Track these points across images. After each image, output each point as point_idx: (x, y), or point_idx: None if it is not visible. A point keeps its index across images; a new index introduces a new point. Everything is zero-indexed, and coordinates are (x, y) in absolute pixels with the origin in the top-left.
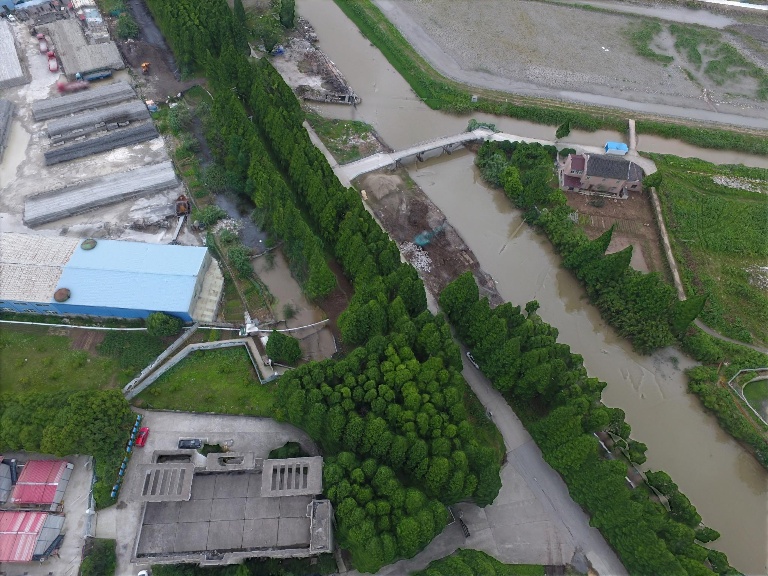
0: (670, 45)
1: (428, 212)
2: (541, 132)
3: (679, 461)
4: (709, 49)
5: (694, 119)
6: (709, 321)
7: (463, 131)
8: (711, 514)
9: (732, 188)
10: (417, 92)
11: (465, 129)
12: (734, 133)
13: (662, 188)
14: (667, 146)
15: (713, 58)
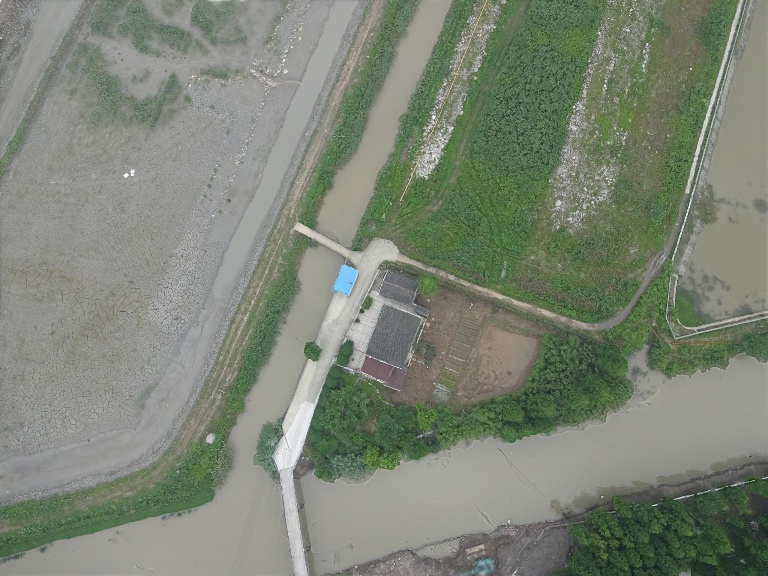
0: (137, 57)
1: (399, 572)
2: (285, 358)
3: (715, 407)
4: (162, 1)
5: (310, 130)
6: (609, 315)
7: (263, 470)
8: (765, 410)
9: (440, 162)
10: (171, 512)
11: (260, 467)
12: (349, 92)
13: (422, 254)
14: (345, 192)
15: (183, 7)
